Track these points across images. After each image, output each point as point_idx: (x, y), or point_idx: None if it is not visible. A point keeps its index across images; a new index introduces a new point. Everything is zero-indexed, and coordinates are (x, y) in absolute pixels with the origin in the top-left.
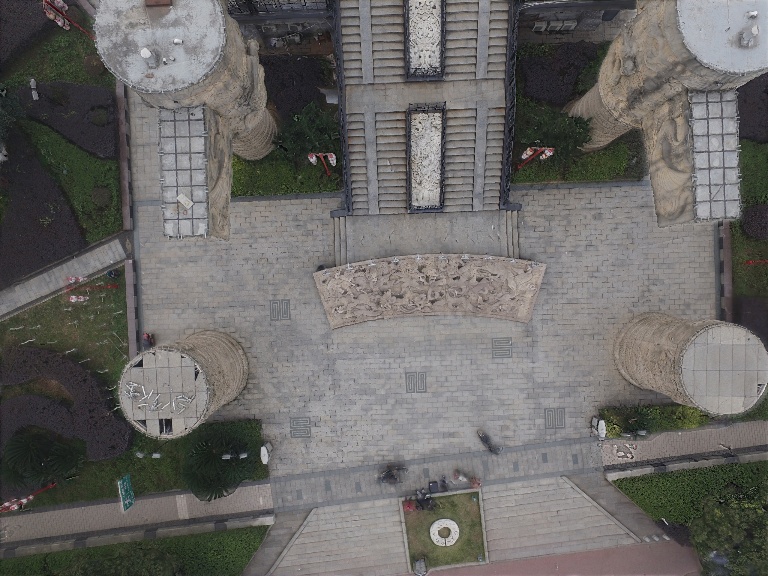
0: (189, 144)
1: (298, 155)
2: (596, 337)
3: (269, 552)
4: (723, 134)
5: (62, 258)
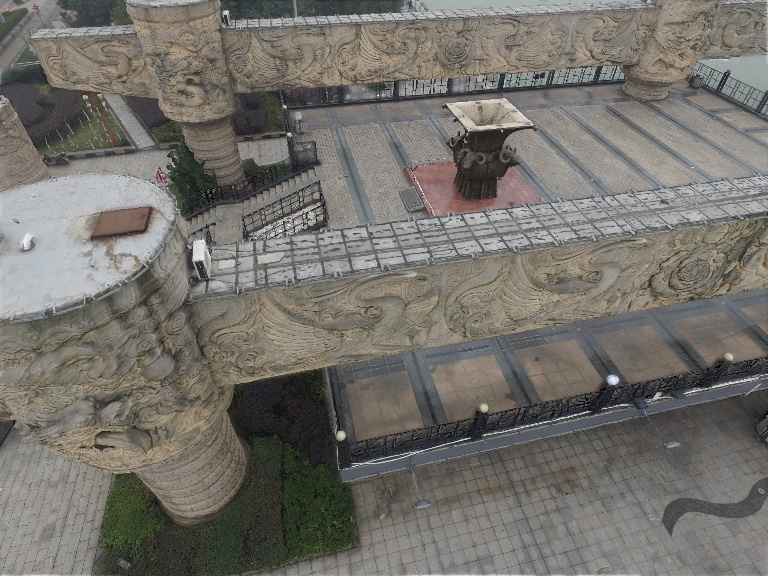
0: (107, 31)
1: None
2: None
3: None
4: None
5: None
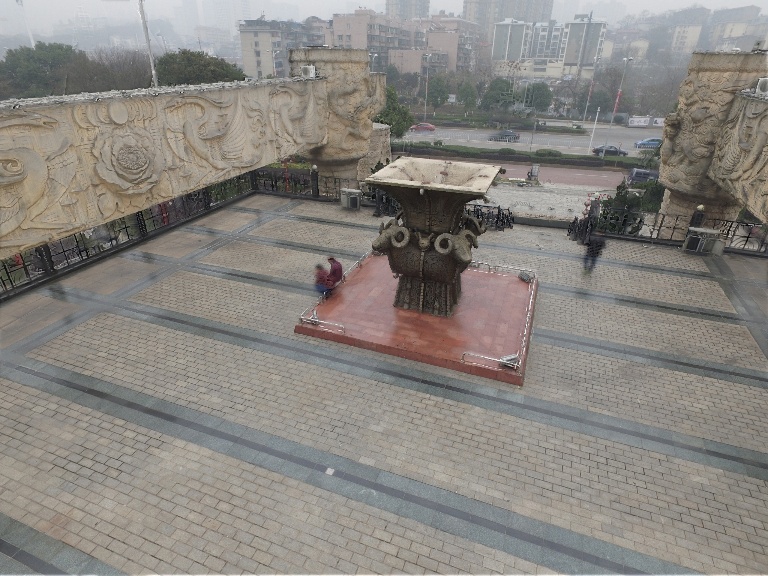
0: None
1: None
2: None
3: None
4: None
5: None
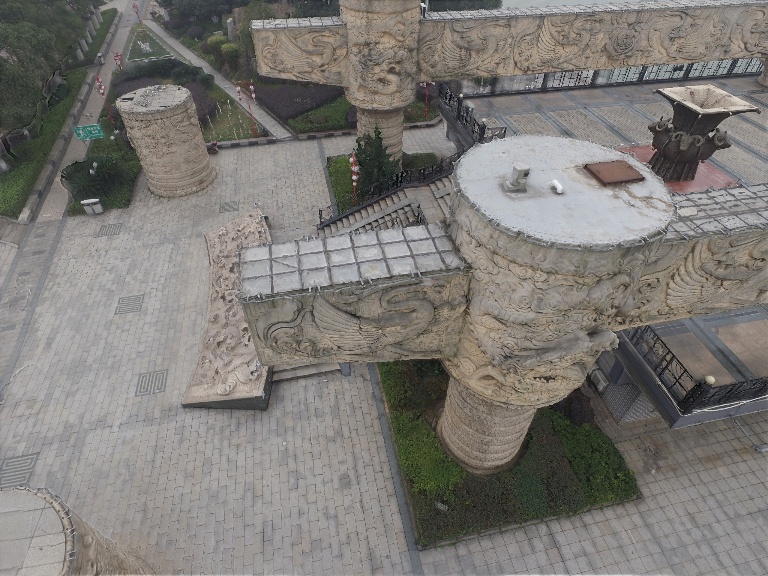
0: (317, 22)
1: None
2: (139, 516)
3: None
4: (386, 259)
5: (277, 117)
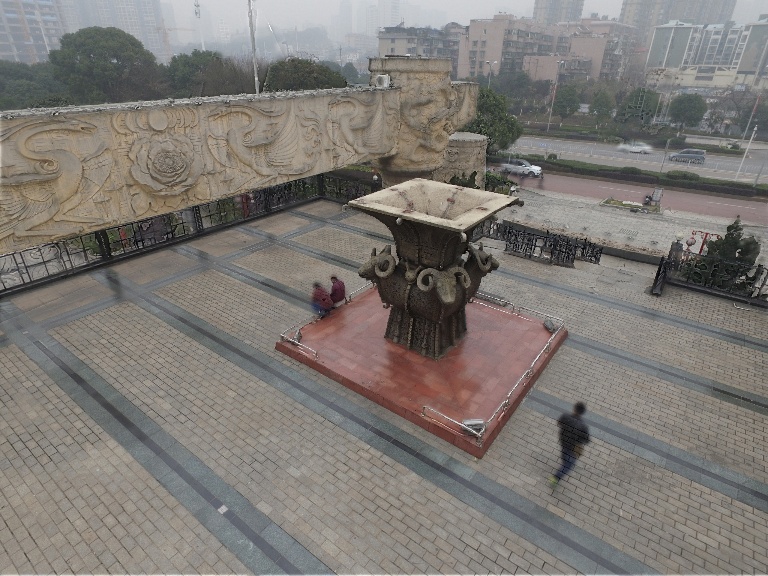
0: None
1: None
2: None
3: None
4: None
5: None
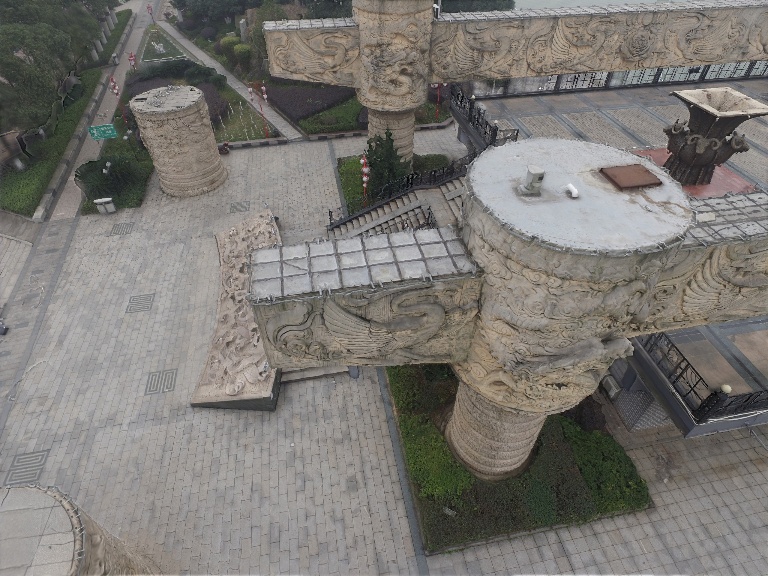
0: None
1: (380, 199)
2: (147, 514)
3: (6, 227)
4: (397, 262)
5: None
